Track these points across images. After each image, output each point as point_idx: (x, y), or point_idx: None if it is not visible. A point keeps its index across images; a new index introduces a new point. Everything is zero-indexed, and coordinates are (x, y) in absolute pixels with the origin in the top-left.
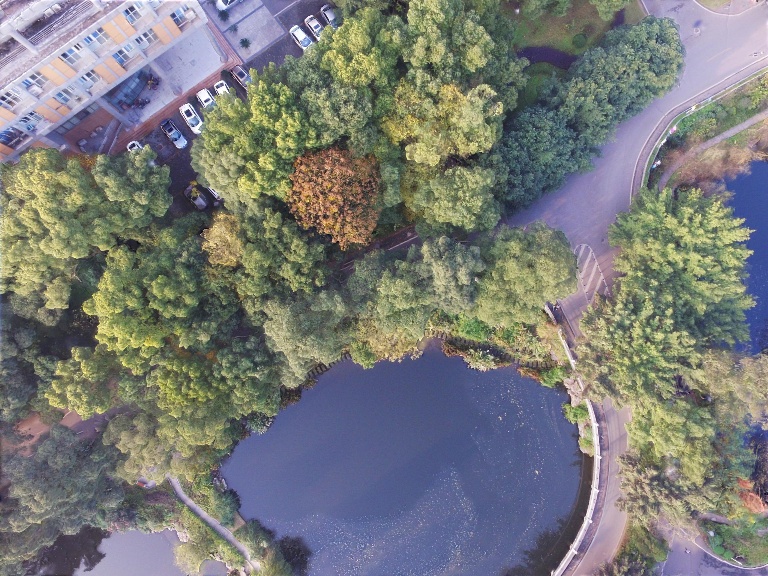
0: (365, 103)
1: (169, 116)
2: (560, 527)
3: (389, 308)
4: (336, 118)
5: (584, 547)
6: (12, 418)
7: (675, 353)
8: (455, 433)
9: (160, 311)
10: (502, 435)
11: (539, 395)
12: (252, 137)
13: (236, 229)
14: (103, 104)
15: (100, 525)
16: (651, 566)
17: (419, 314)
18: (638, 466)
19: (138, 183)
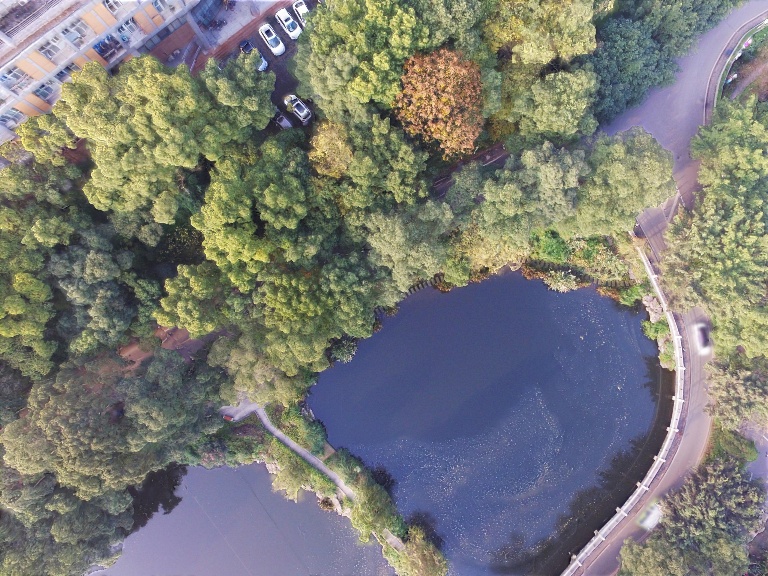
0: (474, 1)
1: (247, 38)
2: (633, 447)
3: (495, 215)
4: (449, 15)
5: (670, 456)
6: (114, 343)
7: (765, 256)
8: (538, 354)
9: (266, 225)
10: (584, 354)
11: (619, 314)
12: (365, 36)
13: (343, 137)
14: (190, 19)
15: (187, 461)
16: (742, 466)
17: (524, 221)
18: (730, 368)
19: (247, 88)
